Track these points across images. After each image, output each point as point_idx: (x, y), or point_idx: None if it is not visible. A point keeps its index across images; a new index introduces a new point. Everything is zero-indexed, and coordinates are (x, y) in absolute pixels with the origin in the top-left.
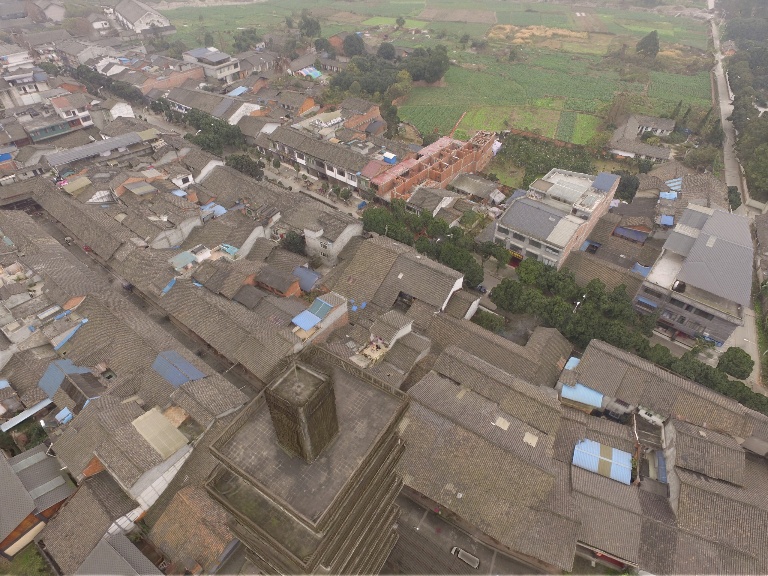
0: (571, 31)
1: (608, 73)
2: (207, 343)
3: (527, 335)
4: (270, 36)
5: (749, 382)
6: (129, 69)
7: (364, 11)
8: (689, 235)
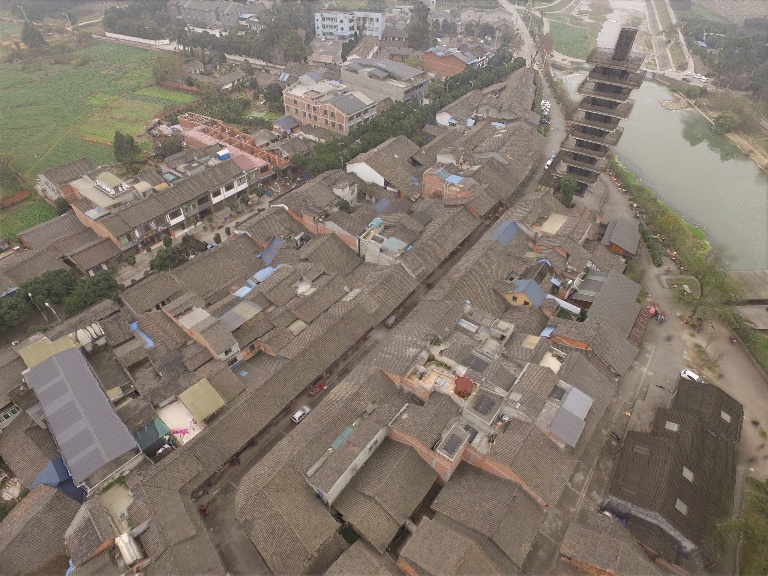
0: None
1: (54, 68)
2: None
3: None
4: None
5: None
6: None
7: None
8: None
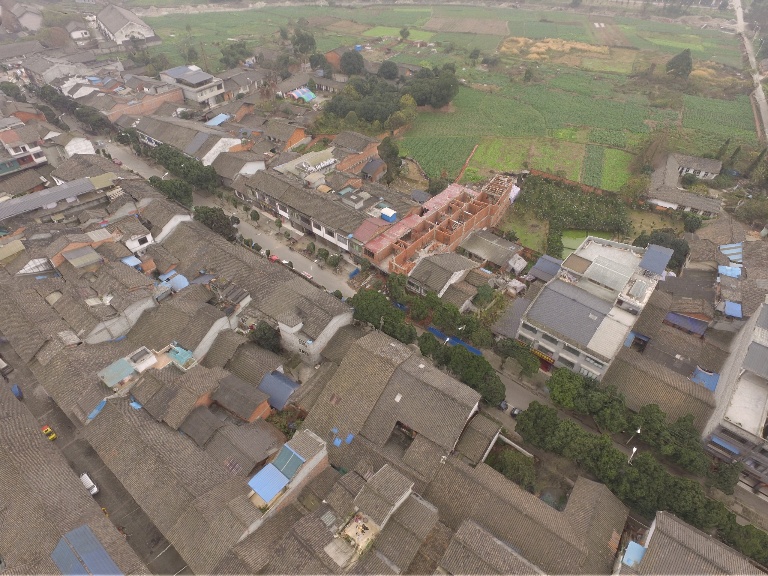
0: (590, 45)
1: (636, 97)
2: (137, 504)
3: (564, 484)
4: (261, 50)
5: None
6: (98, 91)
7: (366, 20)
8: None
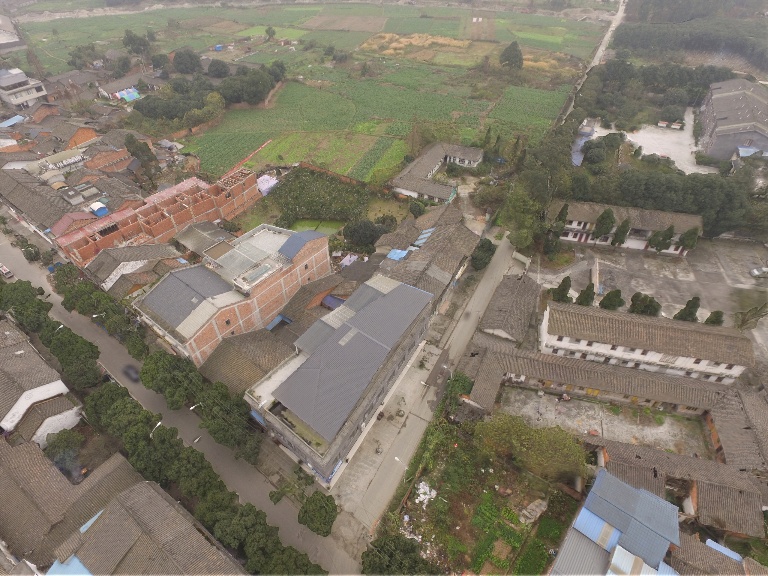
0: (454, 39)
1: (460, 89)
2: None
3: None
4: (112, 52)
5: (361, 528)
6: None
7: (248, 20)
8: (334, 325)
